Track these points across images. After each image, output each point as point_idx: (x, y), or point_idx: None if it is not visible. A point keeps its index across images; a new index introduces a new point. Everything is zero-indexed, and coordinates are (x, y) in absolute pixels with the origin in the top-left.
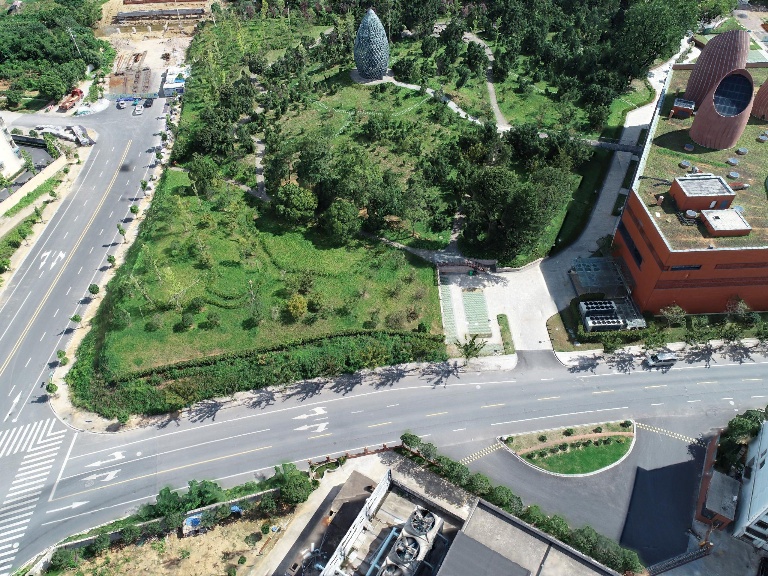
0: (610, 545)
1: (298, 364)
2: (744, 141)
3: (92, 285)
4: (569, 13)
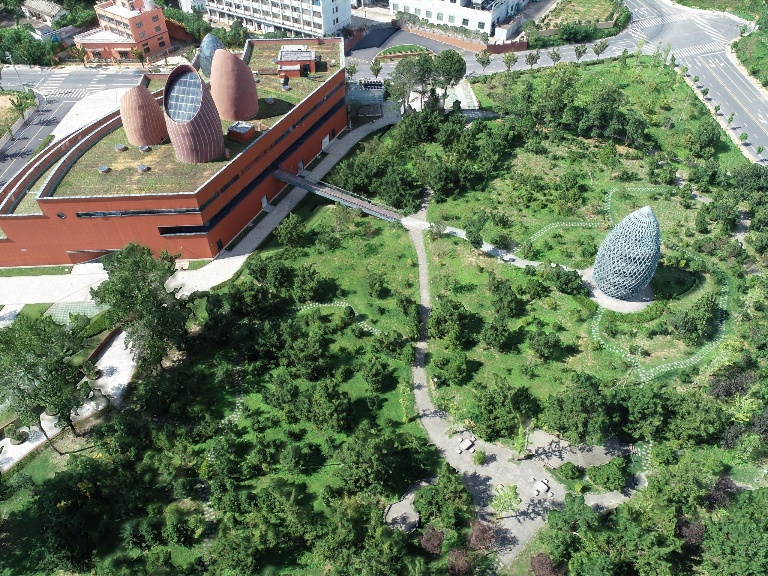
0: None
1: None
2: None
3: (707, 89)
4: (181, 575)
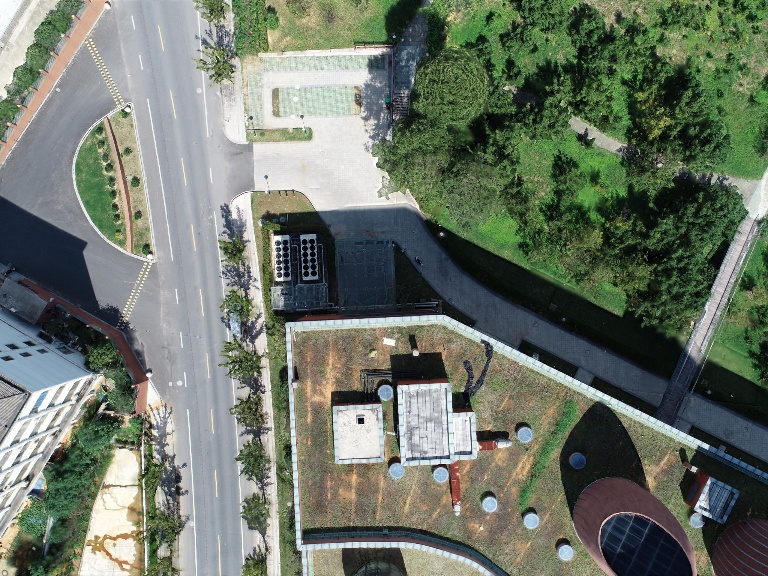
0: None
1: None
2: (602, 570)
3: None
4: None
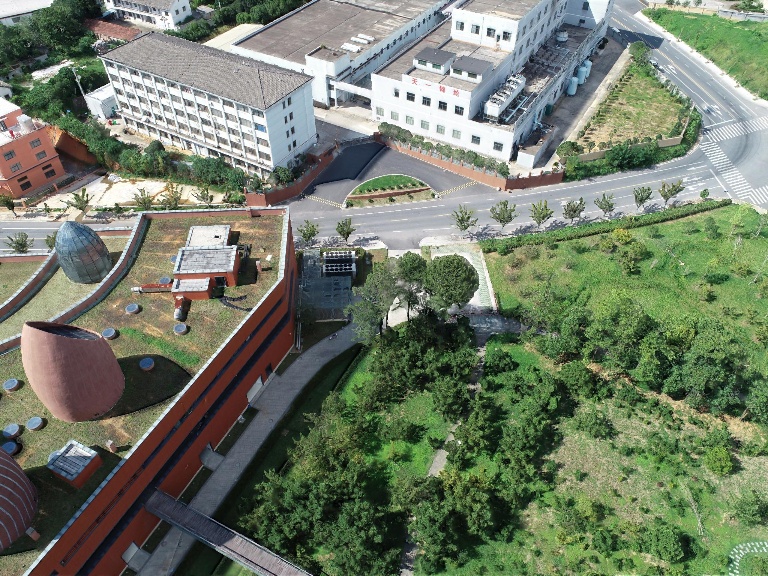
0: (395, 126)
1: (600, 222)
2: None
3: None
4: None
